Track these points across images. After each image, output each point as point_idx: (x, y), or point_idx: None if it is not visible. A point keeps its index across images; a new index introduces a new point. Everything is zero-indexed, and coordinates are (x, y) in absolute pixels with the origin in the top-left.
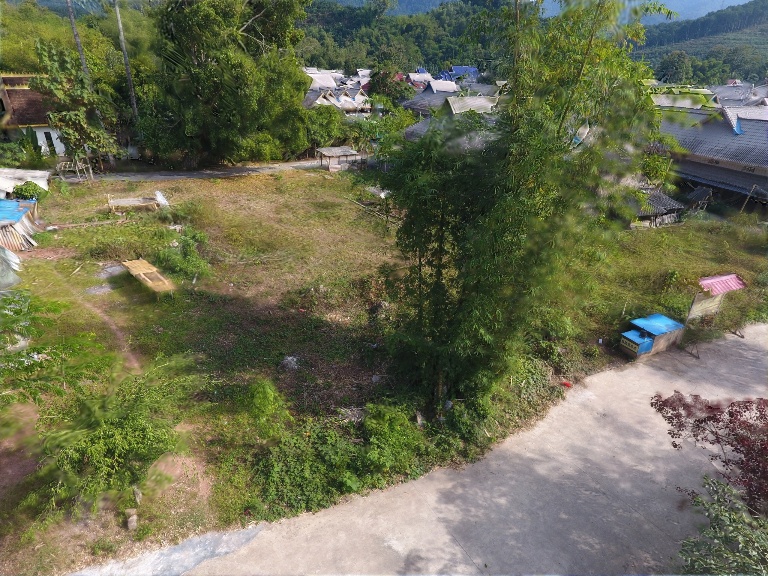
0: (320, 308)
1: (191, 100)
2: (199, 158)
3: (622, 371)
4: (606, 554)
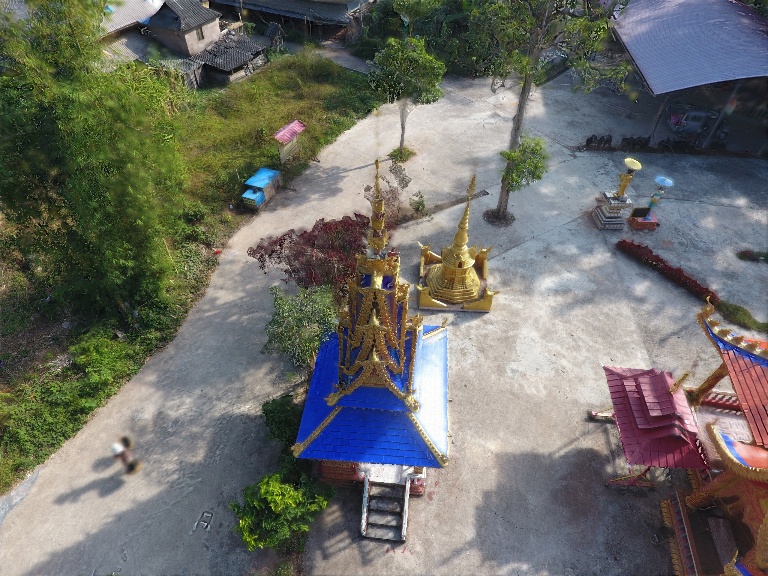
0: None
1: None
2: None
3: (251, 223)
4: (264, 343)
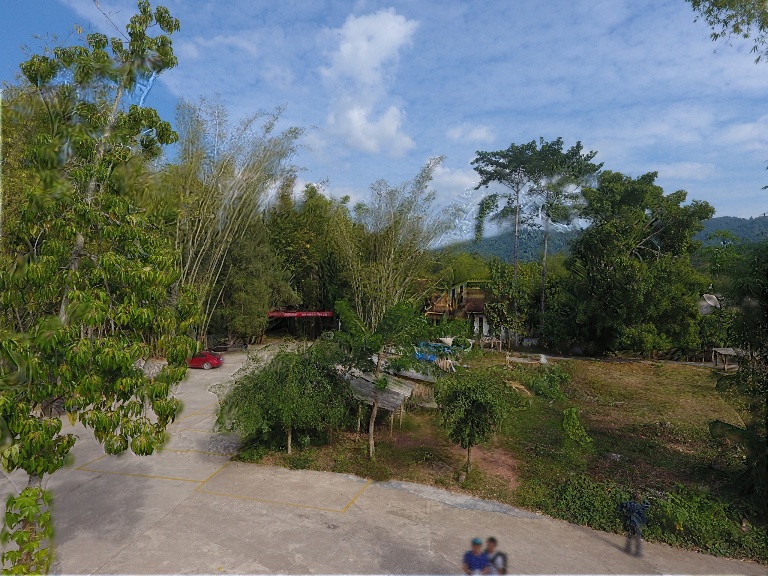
0: (662, 439)
1: (586, 297)
2: (585, 347)
3: None
4: None
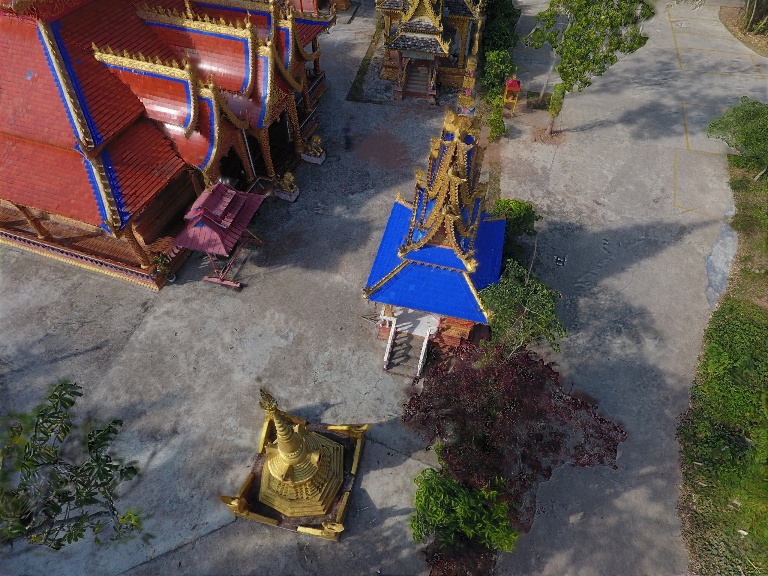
0: None
1: None
2: None
3: None
4: None
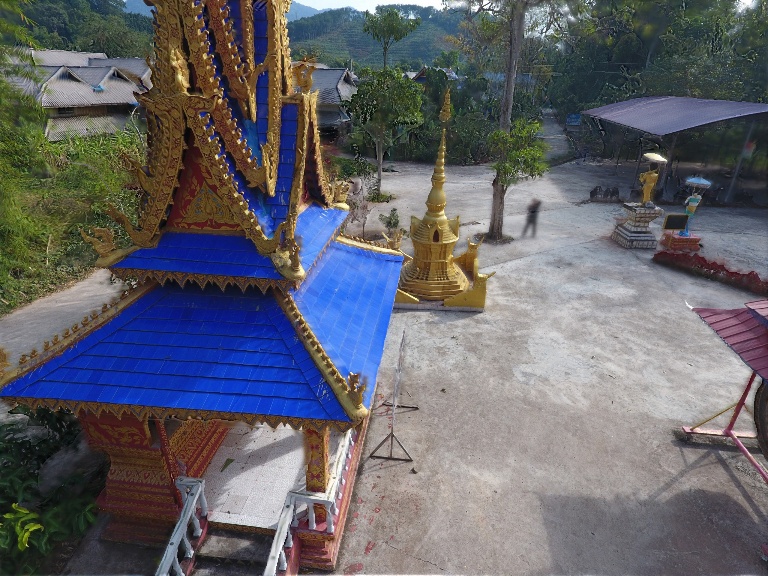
0: None
1: None
2: None
3: None
4: None
